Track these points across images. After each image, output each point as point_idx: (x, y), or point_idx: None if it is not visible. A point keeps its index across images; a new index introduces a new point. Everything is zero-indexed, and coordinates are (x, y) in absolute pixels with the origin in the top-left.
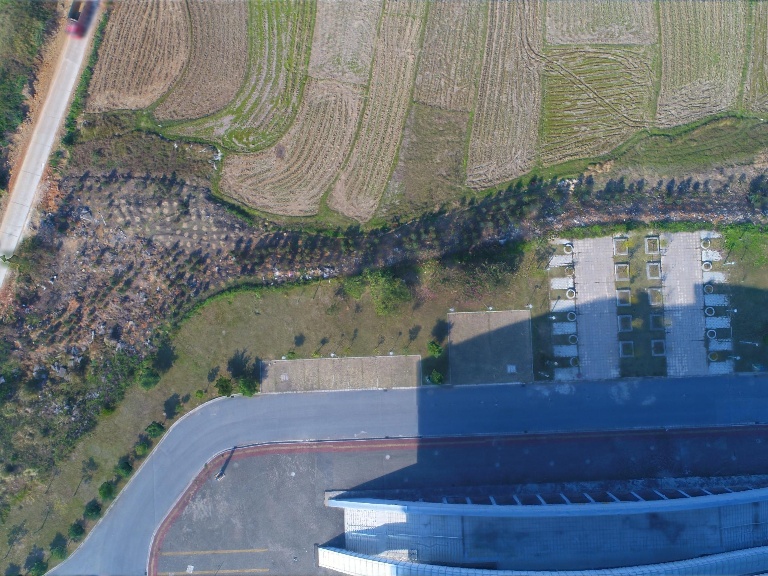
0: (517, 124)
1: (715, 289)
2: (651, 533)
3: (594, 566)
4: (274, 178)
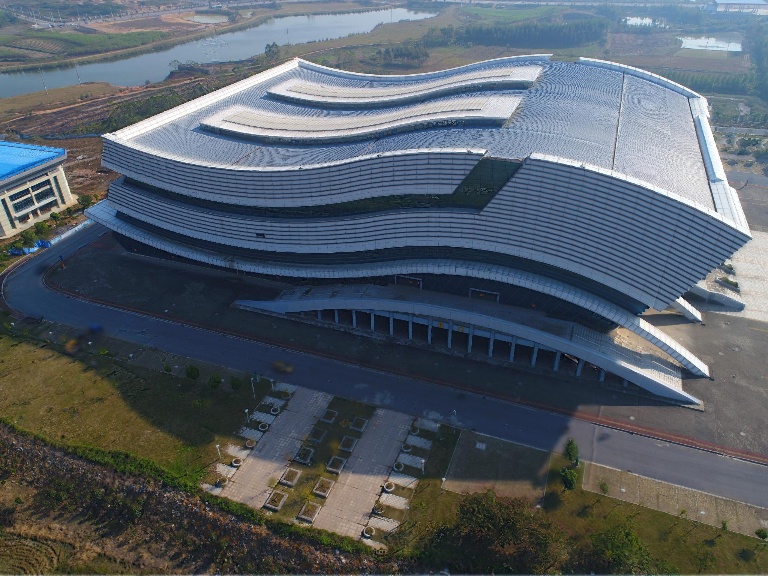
0: None
1: (245, 442)
2: None
3: (468, 299)
4: None
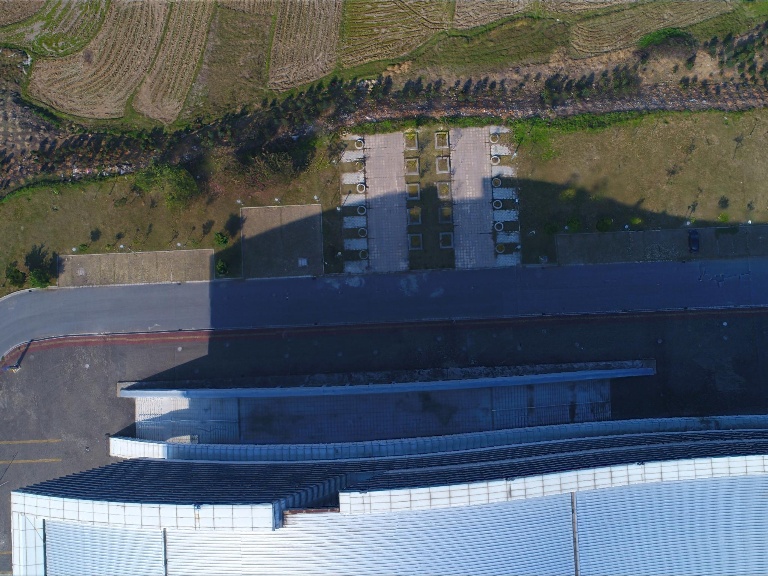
0: (319, 27)
1: (503, 183)
2: (424, 415)
3: None
4: (82, 82)
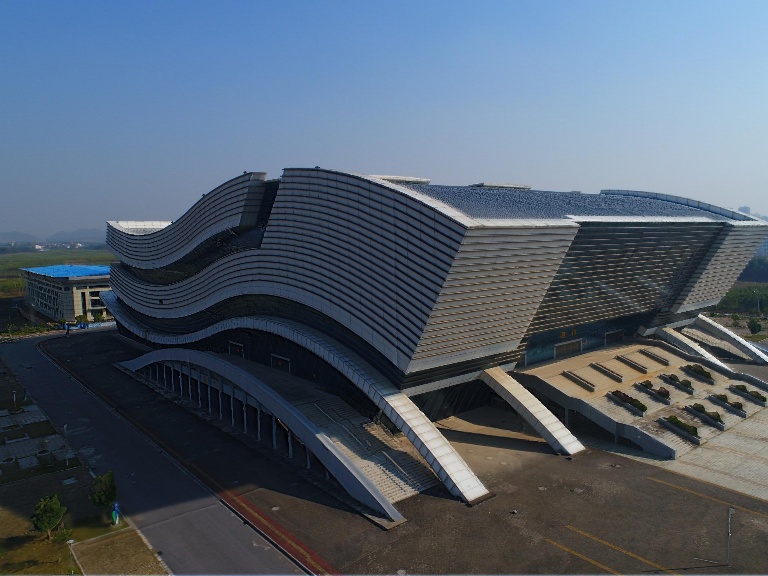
0: None
1: None
2: None
3: (269, 368)
4: None
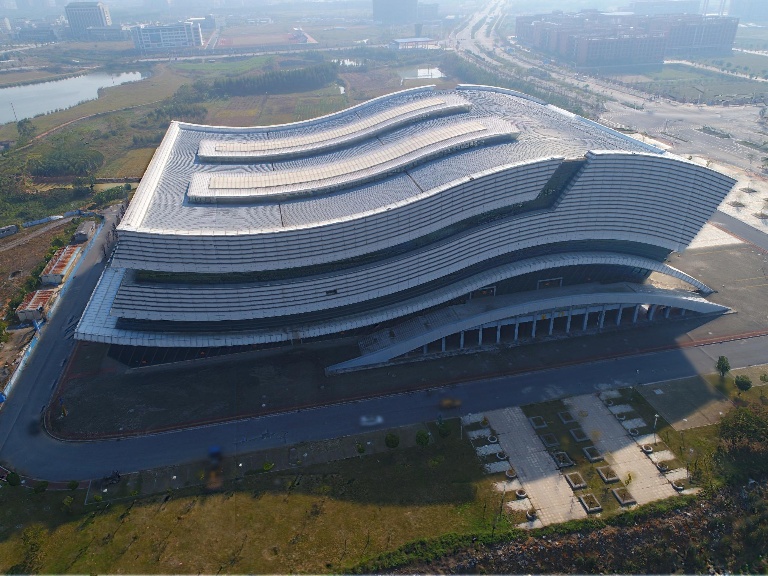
0: None
1: (503, 475)
2: None
3: (536, 291)
4: None
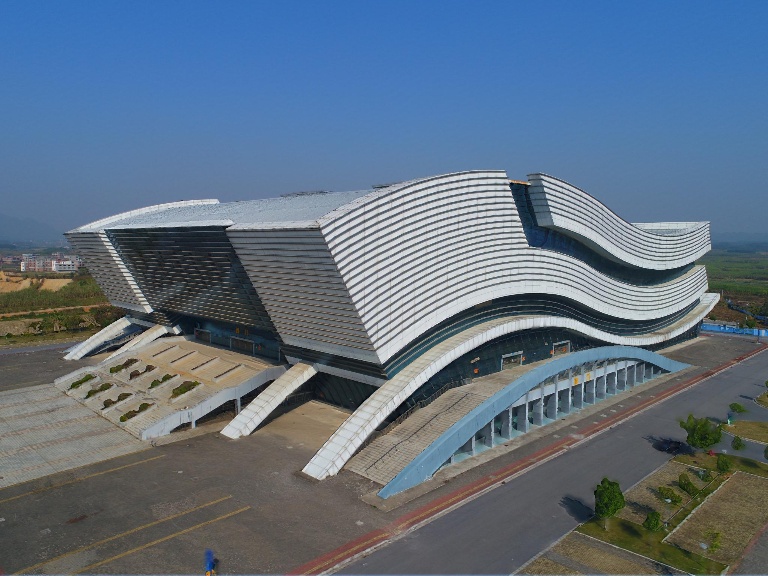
0: None
1: None
2: None
3: None
4: None
